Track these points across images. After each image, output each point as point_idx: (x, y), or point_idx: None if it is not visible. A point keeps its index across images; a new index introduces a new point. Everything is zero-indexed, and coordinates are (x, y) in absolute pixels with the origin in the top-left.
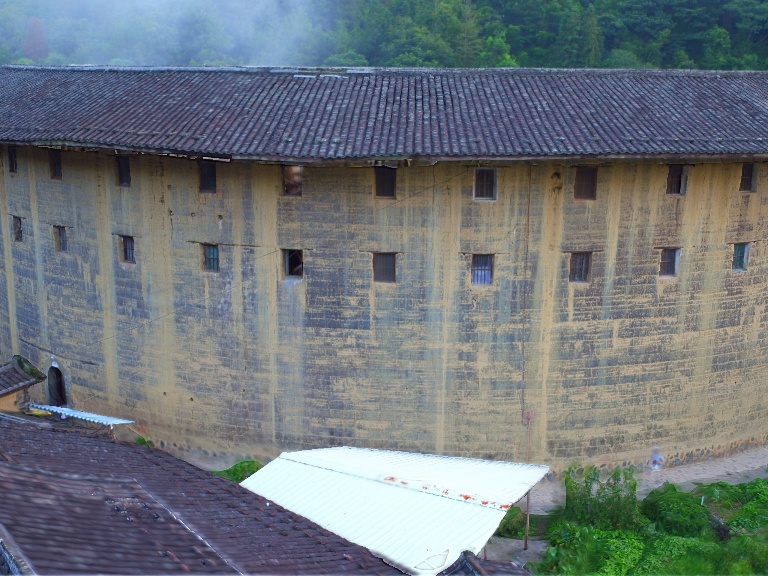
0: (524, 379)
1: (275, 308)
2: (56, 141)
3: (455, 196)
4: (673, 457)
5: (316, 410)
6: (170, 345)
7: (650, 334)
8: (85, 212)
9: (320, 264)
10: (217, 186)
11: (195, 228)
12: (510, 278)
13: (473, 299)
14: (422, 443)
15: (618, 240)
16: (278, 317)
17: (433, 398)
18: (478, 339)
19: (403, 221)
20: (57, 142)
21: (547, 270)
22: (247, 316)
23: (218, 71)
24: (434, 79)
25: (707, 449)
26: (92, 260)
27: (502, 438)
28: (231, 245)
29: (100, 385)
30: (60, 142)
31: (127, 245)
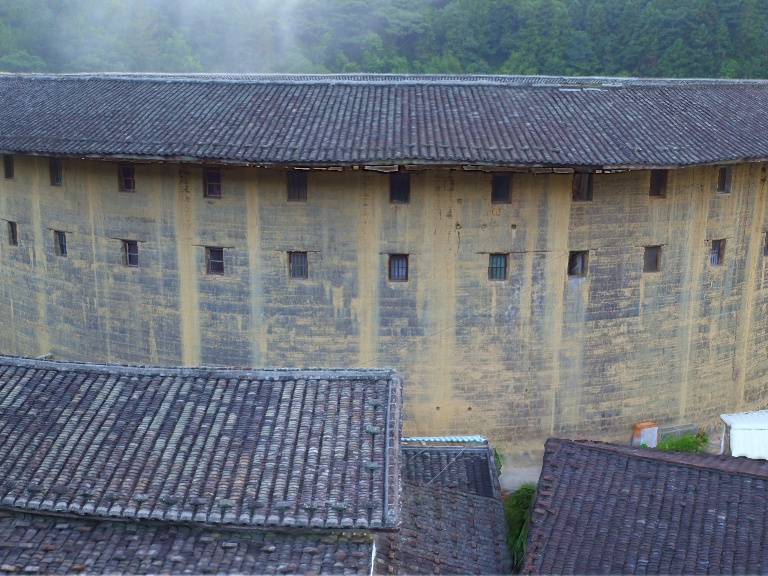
0: (735, 342)
1: (561, 307)
2: (401, 160)
3: (706, 192)
4: None
5: (592, 397)
6: (448, 359)
7: None
8: (342, 234)
9: (603, 262)
10: (514, 197)
11: (486, 239)
12: (733, 258)
13: (711, 279)
14: (671, 410)
15: None
16: (563, 316)
17: (680, 369)
18: (711, 313)
19: (670, 217)
20: (402, 161)
21: (754, 248)
22: (534, 319)
23: (477, 85)
24: (671, 91)
25: None
26: (348, 284)
27: (720, 394)
28: (523, 252)
29: None
30: (406, 161)
31: (391, 264)
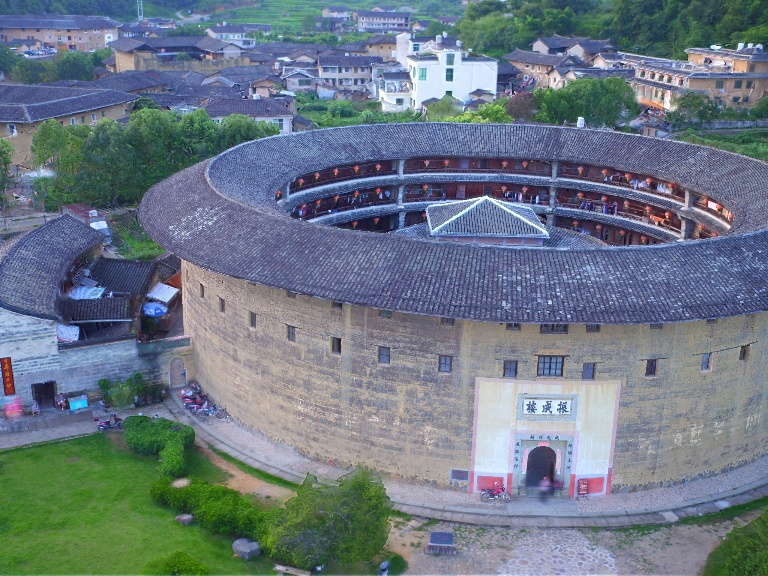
0: None
1: None
2: None
3: None
4: None
5: None
6: None
7: None
8: None
9: None
10: None
11: None
12: None
13: None
14: None
15: None
16: None
17: None
18: None
19: None
20: None
21: None
22: None
23: None
24: None
25: None
26: None
27: None
28: None
29: None
30: None
31: None
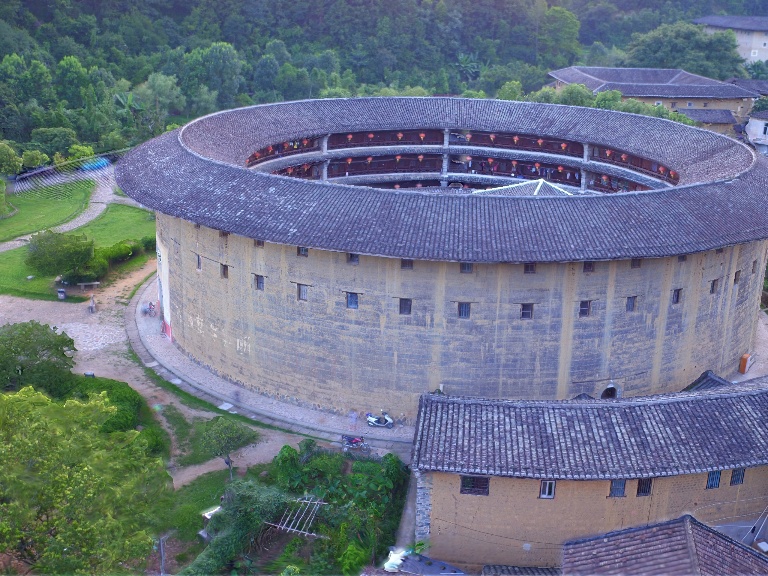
0: None
1: None
2: None
3: None
4: None
5: None
6: None
7: None
8: None
9: None
10: (724, 248)
11: None
12: None
13: None
14: None
15: None
16: None
17: None
18: None
19: None
20: None
21: None
22: None
23: (696, 186)
24: None
25: None
26: (655, 310)
27: None
28: None
29: (647, 383)
30: None
31: None
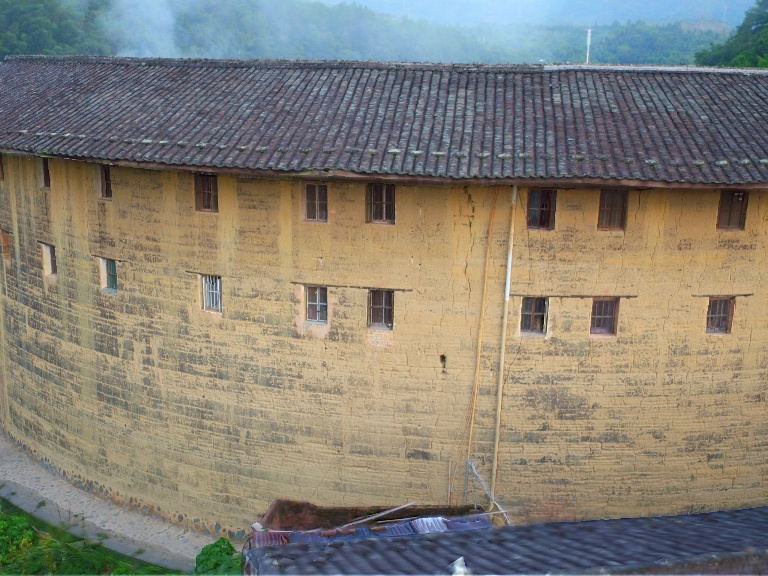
0: None
1: None
2: None
3: None
4: (77, 476)
5: None
6: None
7: (46, 331)
8: None
9: None
10: None
11: None
12: None
13: None
14: None
15: (18, 225)
16: None
17: None
18: None
19: None
20: None
21: None
22: None
23: None
24: None
25: (106, 488)
26: None
27: None
28: None
29: None
30: None
31: None
